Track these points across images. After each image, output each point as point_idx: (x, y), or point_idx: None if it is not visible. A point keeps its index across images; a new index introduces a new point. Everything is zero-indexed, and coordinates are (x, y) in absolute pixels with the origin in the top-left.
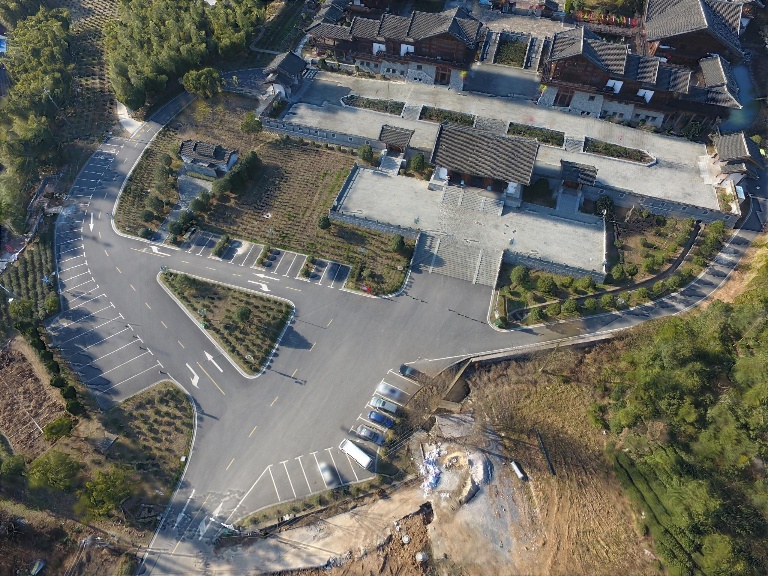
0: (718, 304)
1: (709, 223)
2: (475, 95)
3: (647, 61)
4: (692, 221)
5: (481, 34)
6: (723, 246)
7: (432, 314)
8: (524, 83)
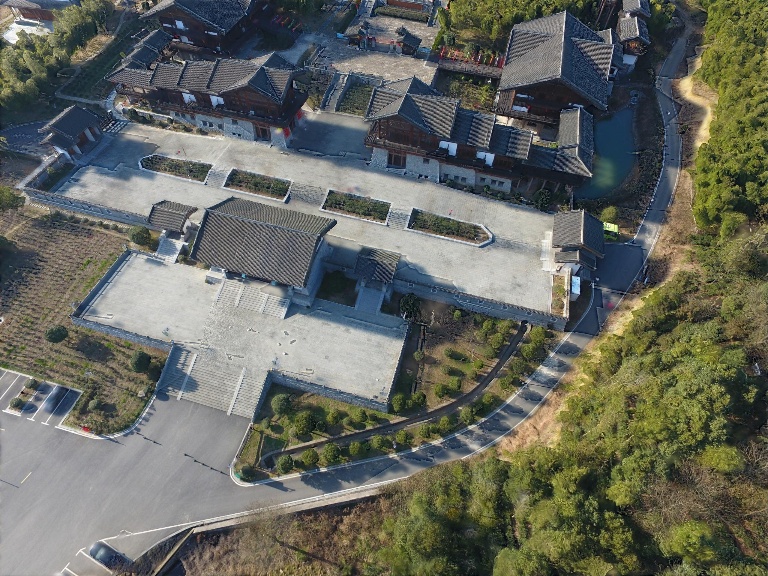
0: (489, 466)
1: (536, 324)
2: (300, 154)
3: (481, 121)
4: (508, 327)
5: (329, 76)
6: (547, 356)
7: (162, 462)
8: (363, 137)
